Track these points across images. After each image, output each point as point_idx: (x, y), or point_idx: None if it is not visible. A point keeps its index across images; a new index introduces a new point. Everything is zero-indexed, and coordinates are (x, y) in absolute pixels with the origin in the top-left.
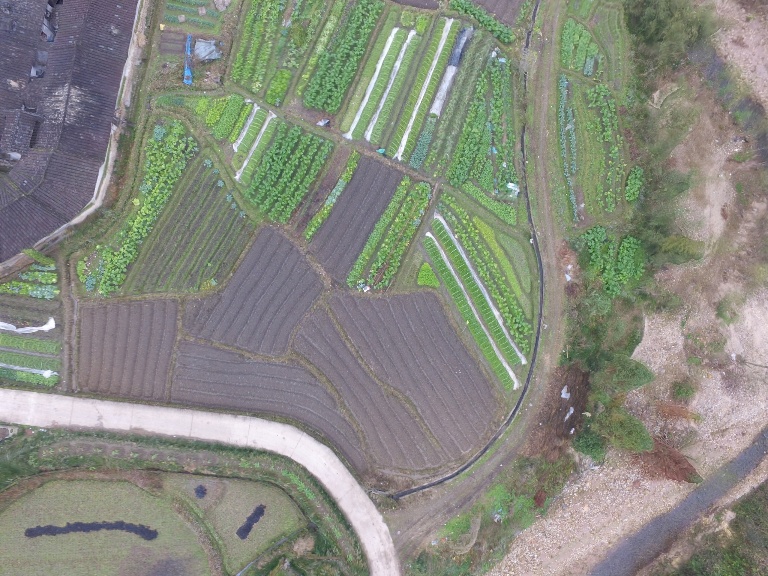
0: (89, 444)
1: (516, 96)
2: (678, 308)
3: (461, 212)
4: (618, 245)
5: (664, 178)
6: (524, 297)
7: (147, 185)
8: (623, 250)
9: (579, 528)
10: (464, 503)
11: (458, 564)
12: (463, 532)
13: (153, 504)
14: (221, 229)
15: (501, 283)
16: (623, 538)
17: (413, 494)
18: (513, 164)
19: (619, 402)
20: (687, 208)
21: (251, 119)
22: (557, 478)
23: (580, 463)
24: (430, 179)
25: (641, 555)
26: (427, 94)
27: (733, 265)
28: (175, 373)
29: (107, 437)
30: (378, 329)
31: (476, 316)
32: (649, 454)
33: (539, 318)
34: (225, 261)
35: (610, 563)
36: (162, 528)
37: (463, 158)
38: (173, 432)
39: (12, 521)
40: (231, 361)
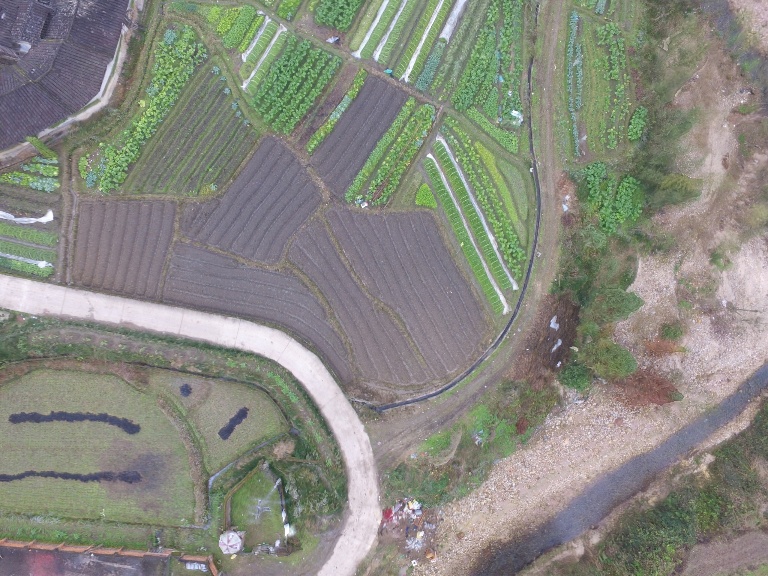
0: (79, 333)
1: (526, 27)
2: (672, 250)
3: (463, 136)
4: (617, 184)
5: (668, 123)
6: (520, 224)
7: (154, 87)
8: (622, 189)
9: (559, 461)
10: (446, 420)
11: (436, 480)
12: (443, 448)
13: (138, 399)
14: (224, 136)
15: (498, 208)
16: (602, 474)
17: (396, 408)
18: (518, 93)
19: (607, 333)
20: (689, 154)
21: (262, 31)
22: (540, 407)
23: (564, 396)
24: (435, 102)
25: (618, 492)
26: (438, 19)
27: (730, 214)
28: (169, 273)
29: (97, 328)
30: (373, 245)
31: (471, 239)
32: (633, 381)
33: (533, 246)
34: (226, 168)
35: (587, 498)
36: (145, 423)
37: (469, 83)
38: (162, 328)
39: None
40: (225, 266)
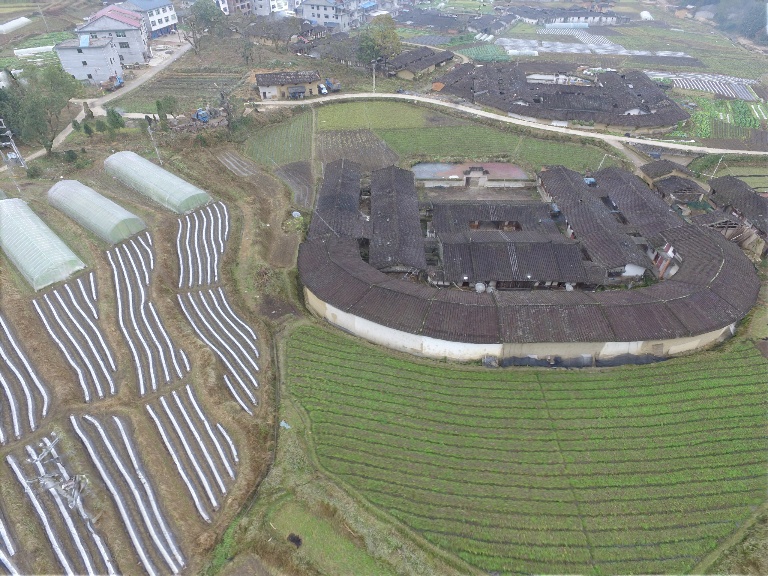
0: None
1: None
2: None
3: None
4: None
5: None
6: None
7: None
8: None
9: None
10: None
11: None
12: None
13: None
14: None
15: None
16: None
17: None
18: None
19: None
20: None
21: None
22: None
23: None
24: None
25: None
26: None
27: None
28: None
29: None
30: None
31: None
32: None
33: None
34: None
35: None
36: None
37: None
38: None
39: None
40: None
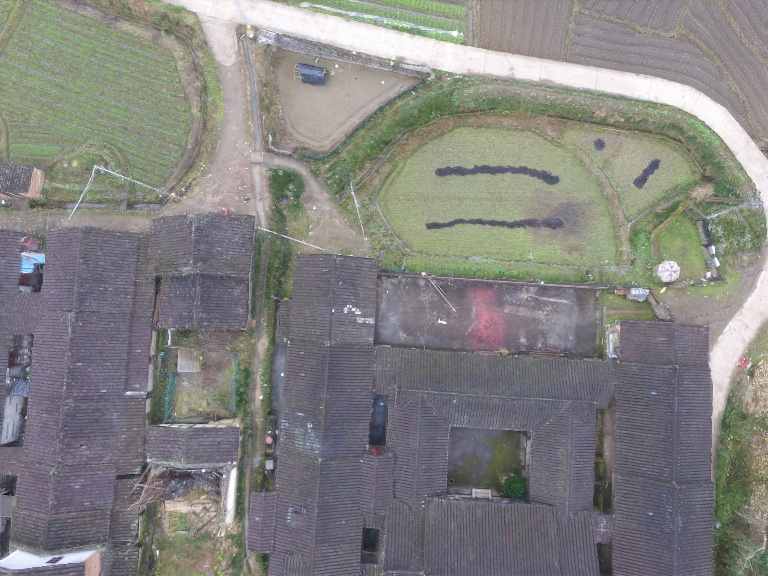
0: (505, 88)
1: None
2: None
3: None
4: None
5: None
6: None
7: None
8: None
9: None
10: None
11: None
12: None
13: (555, 153)
14: None
15: None
16: None
17: None
18: None
19: None
20: None
21: None
22: None
23: None
24: None
25: None
26: None
27: None
28: (571, 41)
29: (522, 83)
30: (760, 13)
31: None
32: None
33: None
34: None
35: None
36: (563, 175)
37: None
38: (580, 85)
39: (423, 161)
40: (623, 34)
